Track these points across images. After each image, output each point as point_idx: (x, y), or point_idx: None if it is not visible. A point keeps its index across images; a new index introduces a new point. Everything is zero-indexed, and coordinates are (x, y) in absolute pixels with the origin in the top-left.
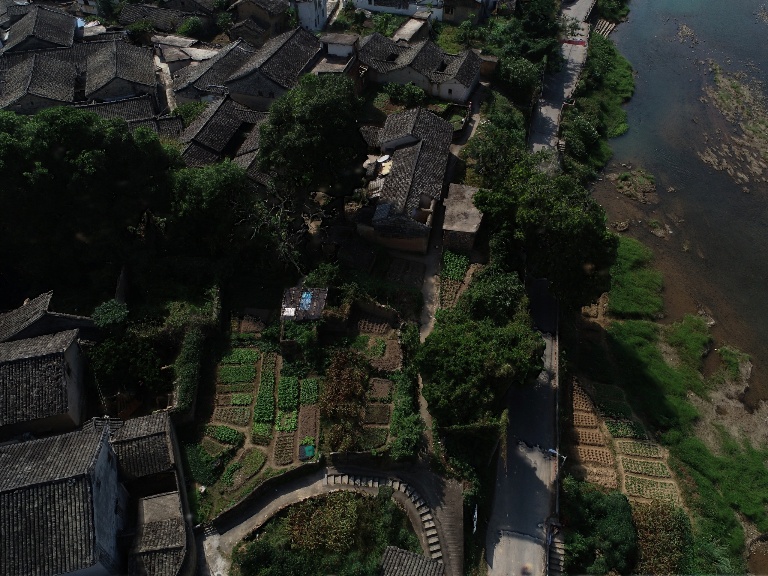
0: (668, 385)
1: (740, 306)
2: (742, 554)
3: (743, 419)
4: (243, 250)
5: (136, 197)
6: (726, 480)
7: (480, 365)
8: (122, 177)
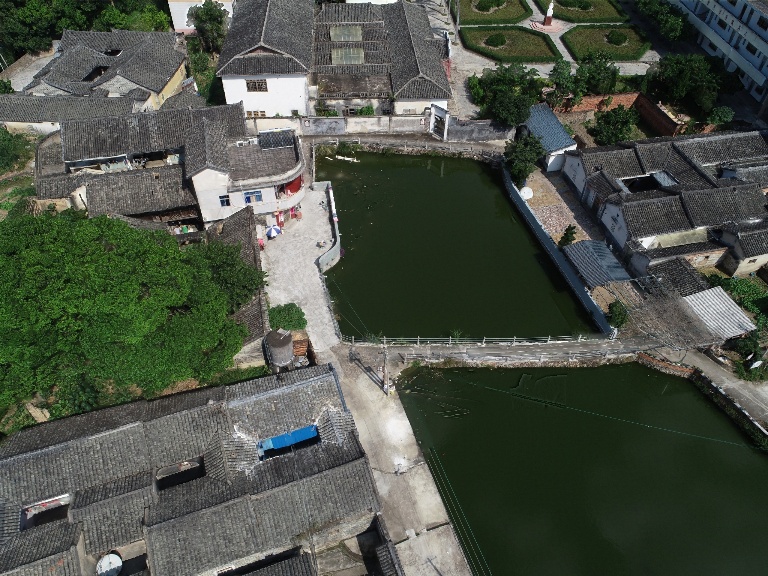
0: None
1: None
2: None
3: None
4: None
5: None
6: None
7: None
8: None
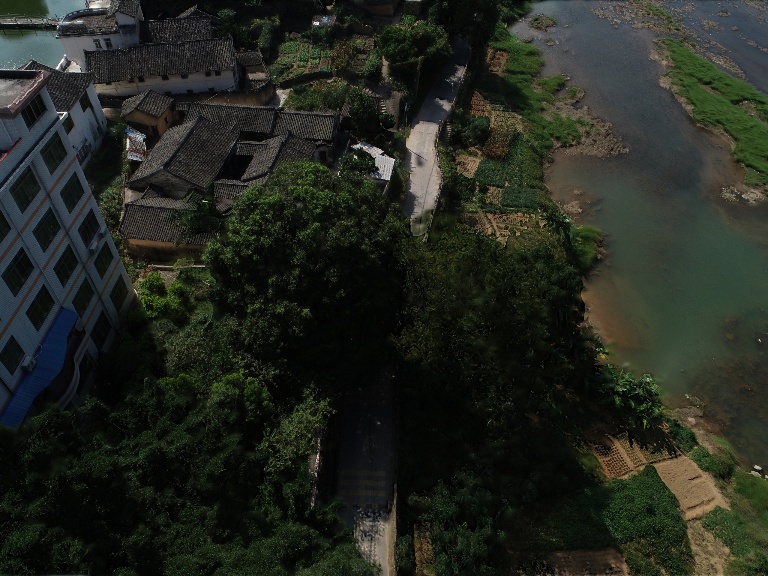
0: (531, 97)
1: (589, 73)
2: (550, 151)
3: (571, 112)
4: (291, 2)
5: None
6: (550, 127)
7: (411, 35)
8: None
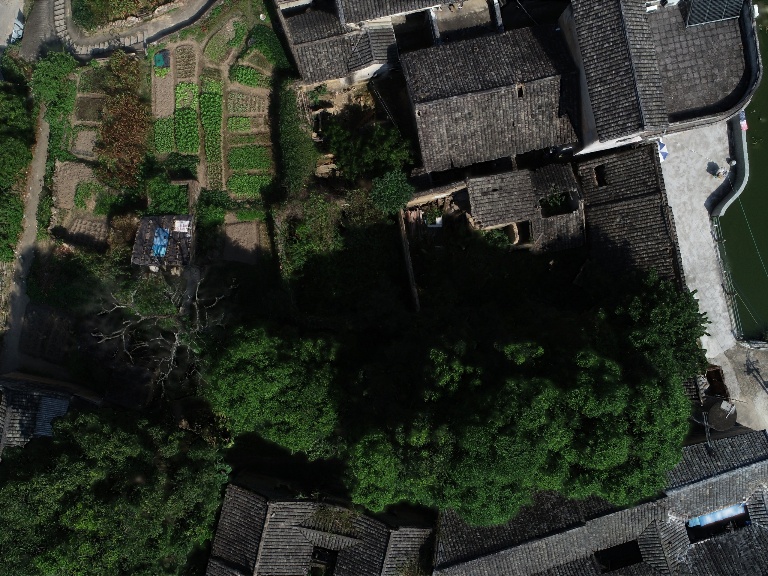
0: None
1: None
2: None
3: None
4: None
5: (389, 367)
6: None
7: None
8: None
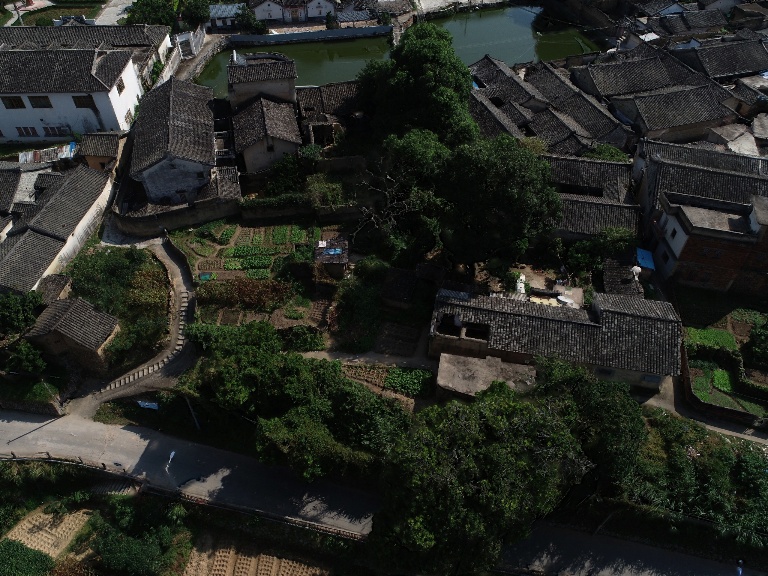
0: None
1: None
2: None
3: None
4: None
5: None
6: None
7: None
8: (415, 107)
